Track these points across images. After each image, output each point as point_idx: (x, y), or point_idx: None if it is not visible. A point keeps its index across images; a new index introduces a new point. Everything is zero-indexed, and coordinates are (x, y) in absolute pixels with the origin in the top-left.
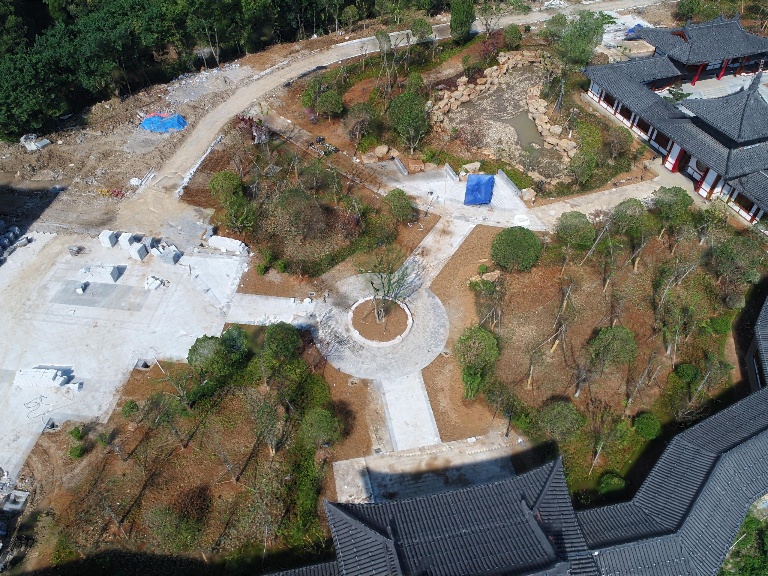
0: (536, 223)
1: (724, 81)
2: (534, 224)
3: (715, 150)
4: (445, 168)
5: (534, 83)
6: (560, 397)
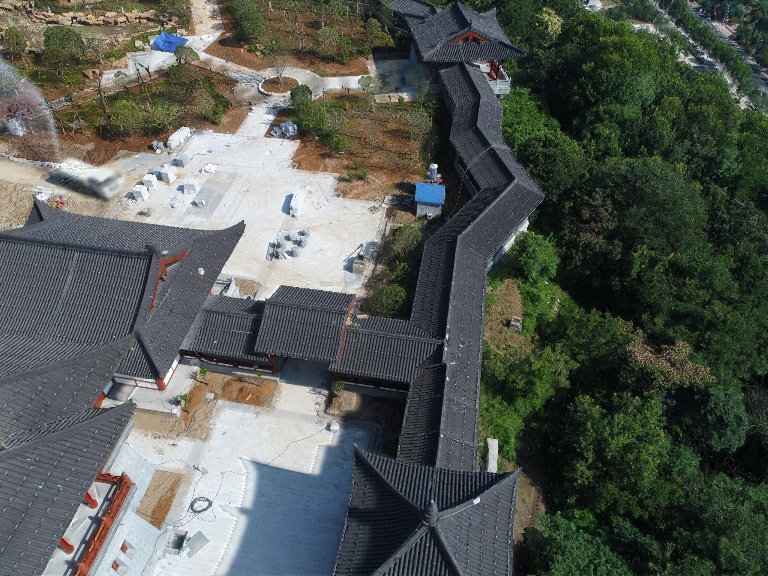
0: (212, 35)
1: None
2: (213, 35)
3: None
4: (129, 56)
5: (25, 18)
6: (351, 40)
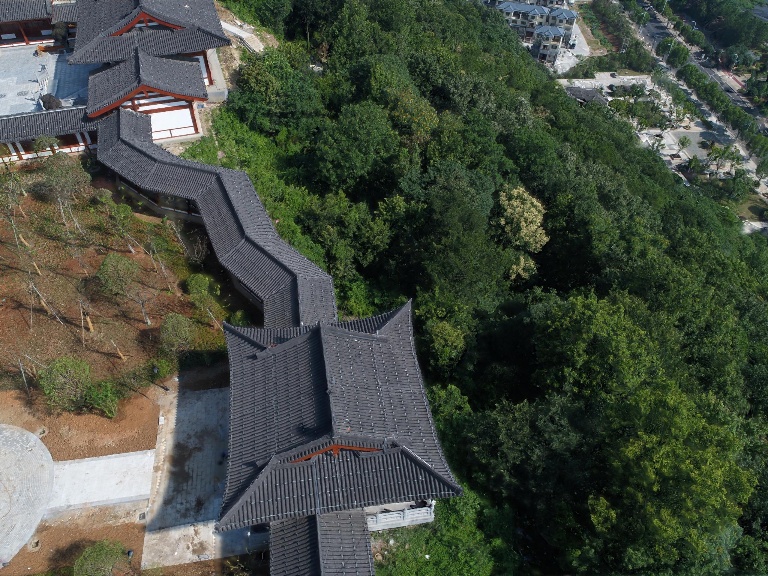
0: None
1: None
2: None
3: None
4: None
5: None
6: (145, 336)
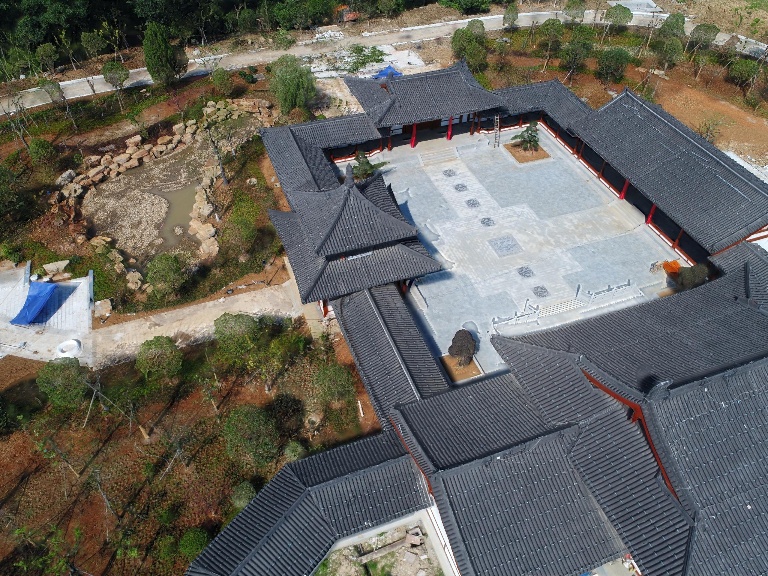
0: (85, 353)
1: (455, 141)
2: (81, 355)
3: (314, 260)
4: None
5: None
6: None
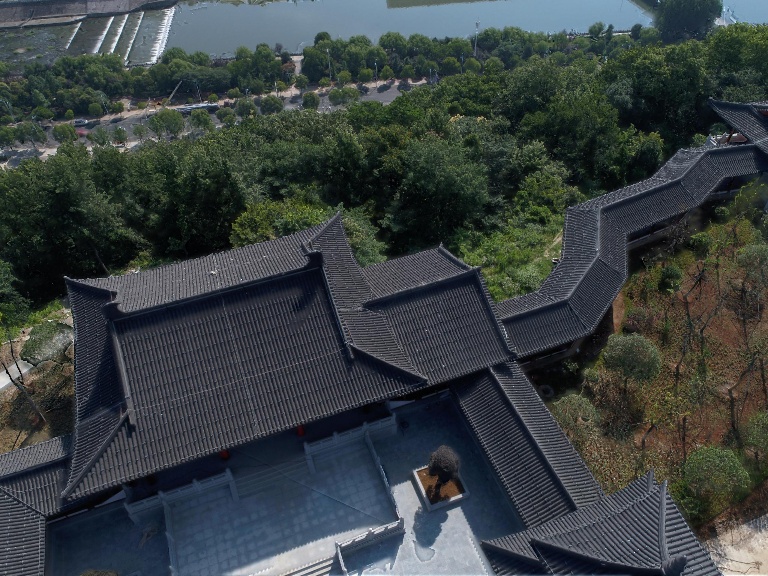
0: None
1: None
2: None
3: None
4: None
5: None
6: None
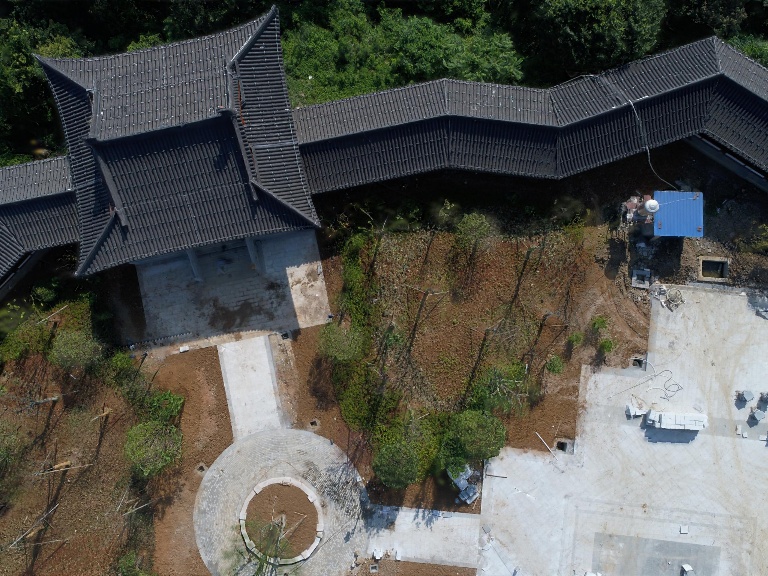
0: None
1: None
2: None
3: None
4: None
5: None
6: (75, 398)
